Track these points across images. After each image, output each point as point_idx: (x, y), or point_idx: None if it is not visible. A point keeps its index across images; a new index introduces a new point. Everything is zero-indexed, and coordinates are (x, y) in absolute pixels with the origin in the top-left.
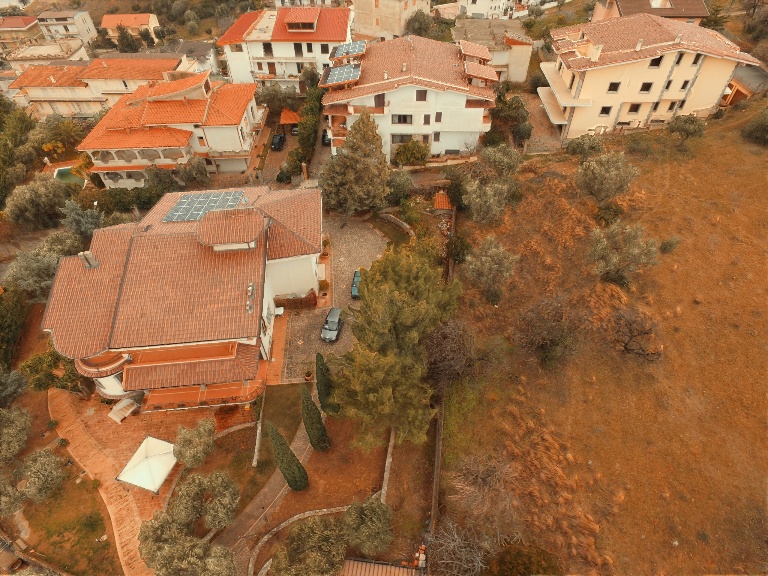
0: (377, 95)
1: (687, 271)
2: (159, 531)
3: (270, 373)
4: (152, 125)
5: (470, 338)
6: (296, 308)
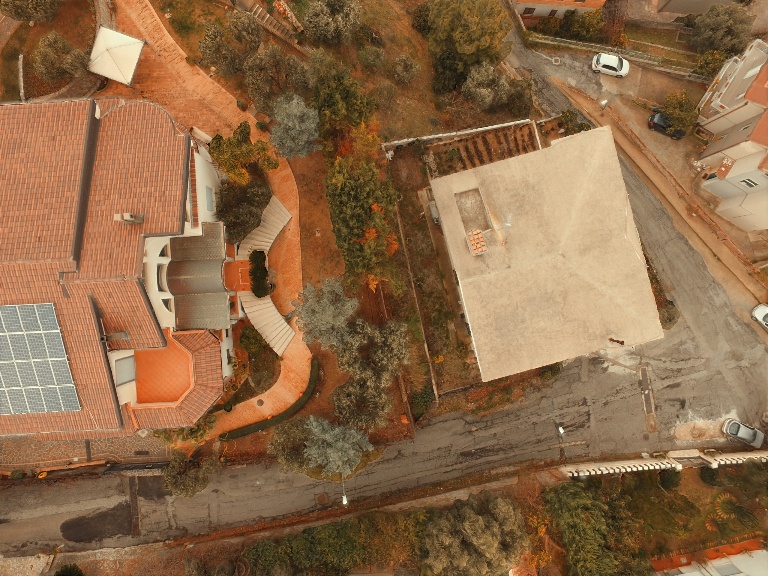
0: None
1: None
2: None
3: None
4: None
5: None
6: None
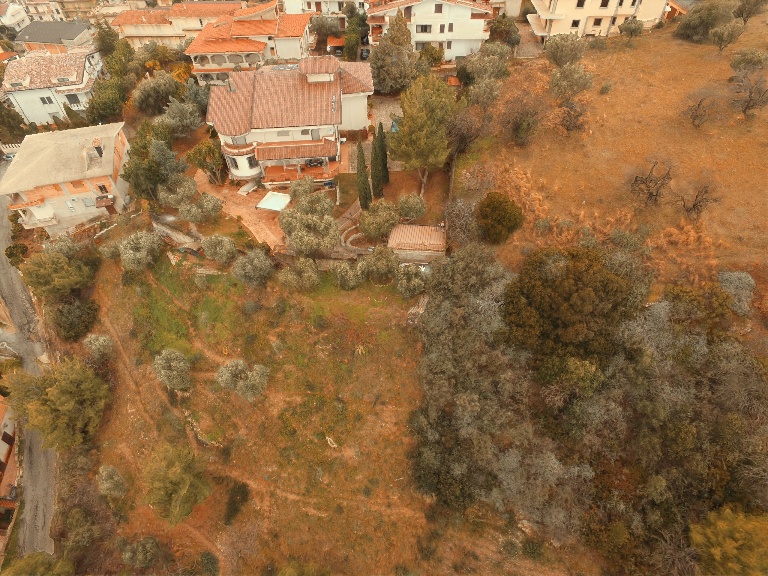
0: (406, 8)
1: (615, 101)
2: (291, 214)
3: (341, 168)
4: (238, 37)
5: (471, 119)
6: (354, 140)
